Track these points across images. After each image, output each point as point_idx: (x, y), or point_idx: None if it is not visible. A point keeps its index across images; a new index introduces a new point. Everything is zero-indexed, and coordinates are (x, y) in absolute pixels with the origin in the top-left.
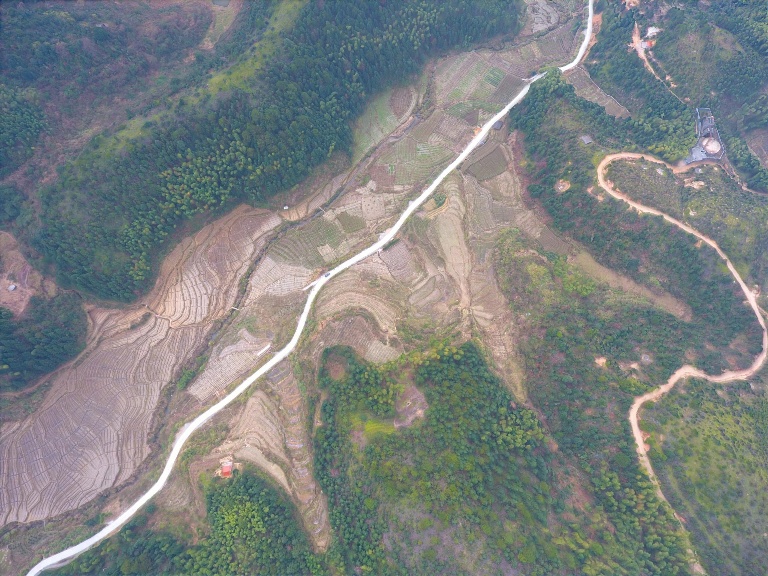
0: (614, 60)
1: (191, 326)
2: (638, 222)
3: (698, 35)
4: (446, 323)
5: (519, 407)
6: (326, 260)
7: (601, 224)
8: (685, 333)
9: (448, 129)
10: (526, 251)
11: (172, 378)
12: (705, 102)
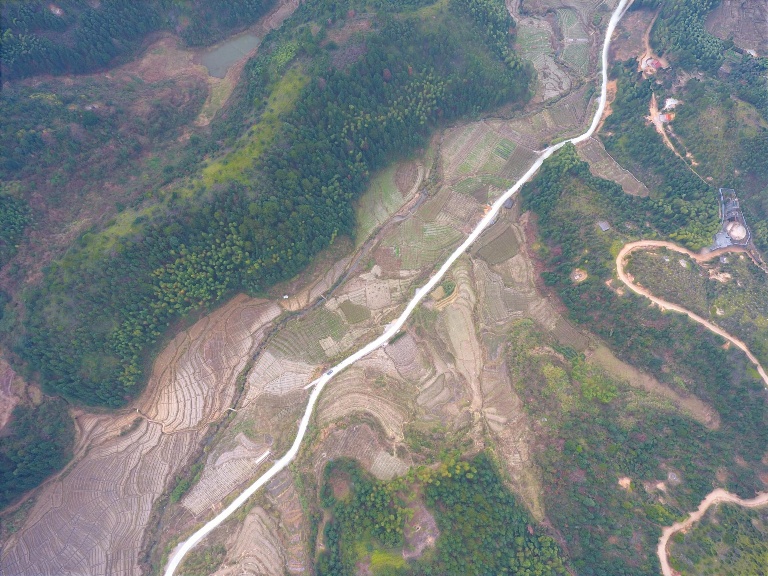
0: (631, 134)
1: (185, 431)
2: (661, 319)
3: (720, 110)
4: (456, 427)
5: (536, 529)
6: (328, 354)
7: (621, 319)
8: (714, 447)
9: (456, 207)
10: (541, 348)
11: (165, 490)
12: (729, 183)
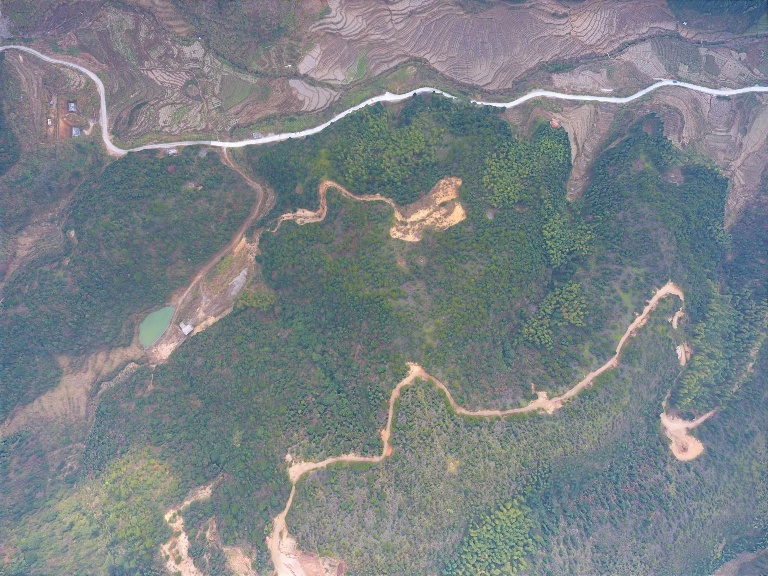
0: None
1: (580, 42)
2: None
3: None
4: None
5: None
6: (679, 74)
7: None
8: None
9: None
10: None
11: (550, 61)
12: None
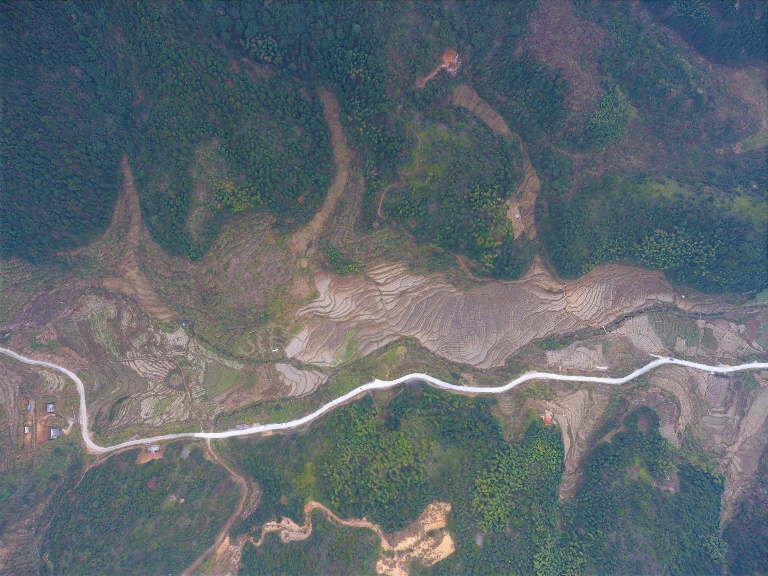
0: None
1: (576, 317)
2: None
3: None
4: (712, 450)
5: None
6: (676, 348)
7: None
8: None
9: None
10: None
11: (544, 337)
12: None
